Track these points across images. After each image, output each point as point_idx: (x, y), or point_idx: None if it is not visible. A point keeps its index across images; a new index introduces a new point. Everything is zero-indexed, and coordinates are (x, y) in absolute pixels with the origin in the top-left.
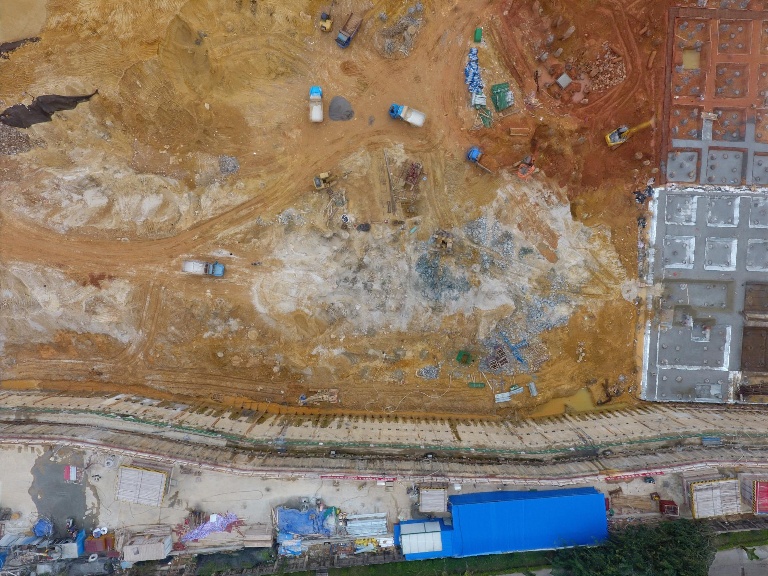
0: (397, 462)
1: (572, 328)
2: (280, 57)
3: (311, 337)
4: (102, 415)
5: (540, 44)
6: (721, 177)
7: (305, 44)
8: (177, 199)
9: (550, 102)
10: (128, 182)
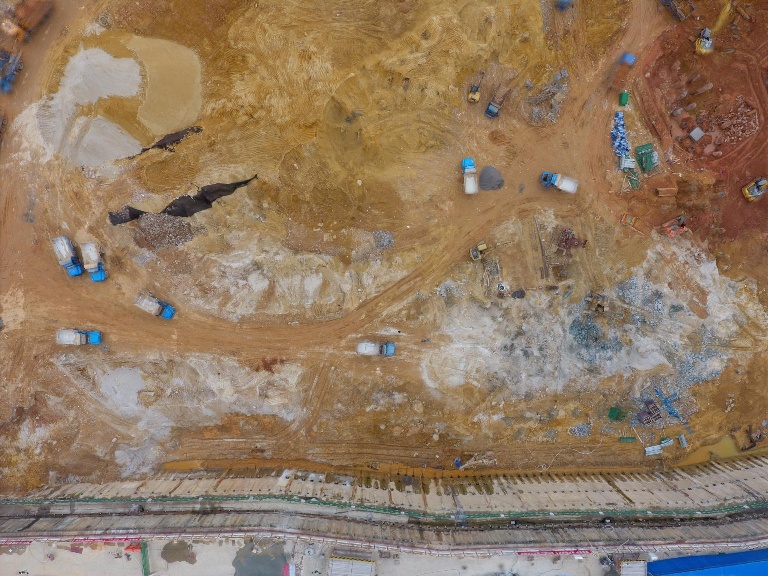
0: (580, 530)
1: (723, 381)
2: (431, 131)
3: (473, 406)
4: (288, 500)
5: (673, 100)
6: None
7: (453, 116)
8: (338, 278)
9: (683, 156)
10: (288, 263)
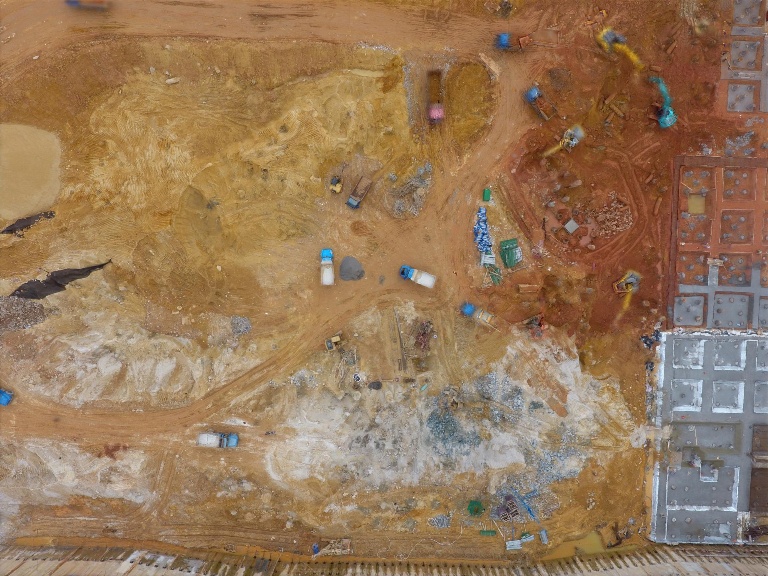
0: None
1: (582, 480)
2: (291, 220)
3: (324, 496)
4: None
5: (547, 192)
6: (727, 320)
7: (315, 205)
8: (190, 363)
9: (557, 247)
10: (141, 347)
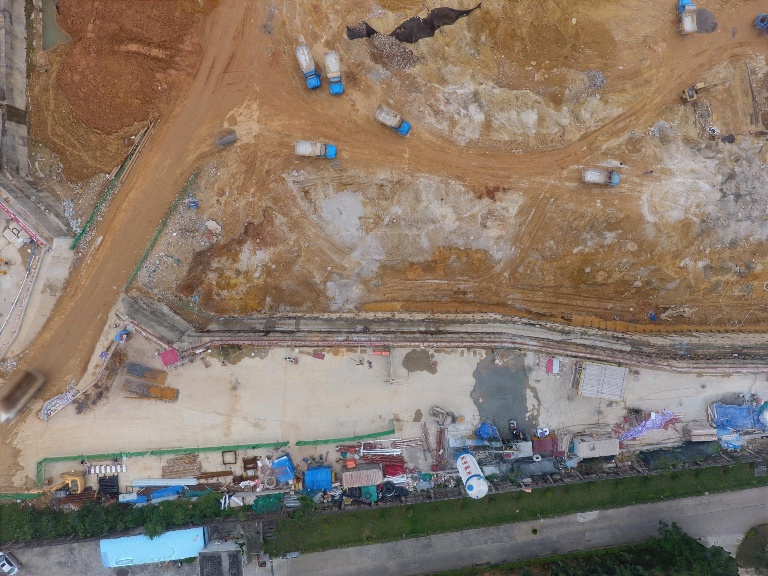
0: None
1: None
2: None
3: (682, 249)
4: (515, 323)
5: None
6: None
7: None
8: (554, 113)
9: None
10: (505, 97)
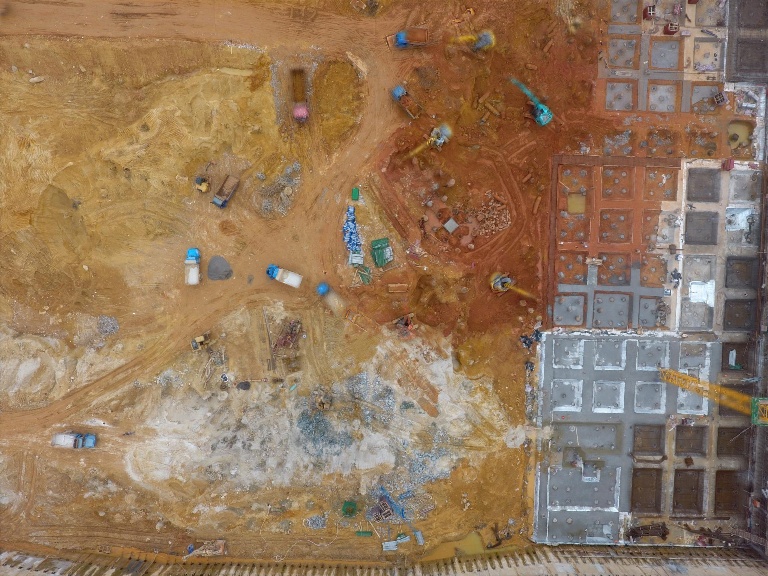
0: None
1: (454, 481)
2: (157, 220)
3: (191, 497)
4: None
5: (425, 191)
6: (608, 320)
7: (183, 204)
8: (54, 364)
9: (438, 246)
10: (5, 347)
